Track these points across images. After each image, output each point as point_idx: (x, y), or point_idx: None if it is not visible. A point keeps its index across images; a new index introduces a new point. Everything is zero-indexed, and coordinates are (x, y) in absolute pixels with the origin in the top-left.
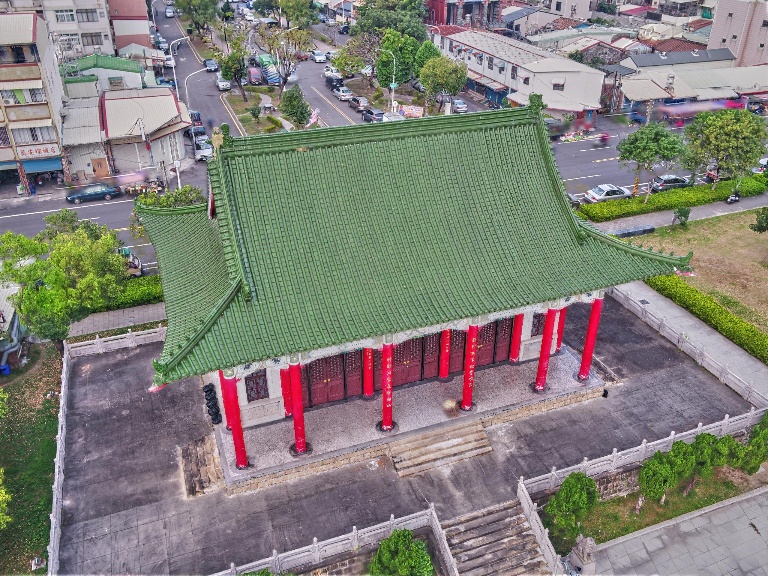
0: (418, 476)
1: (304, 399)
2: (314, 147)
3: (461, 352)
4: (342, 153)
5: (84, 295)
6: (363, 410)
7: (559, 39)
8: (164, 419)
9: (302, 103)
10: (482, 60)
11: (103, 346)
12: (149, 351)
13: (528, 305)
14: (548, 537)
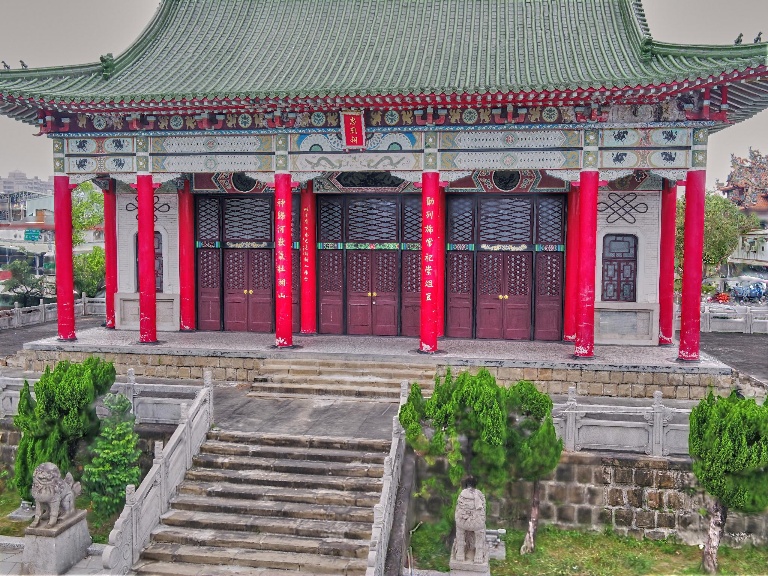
0: (272, 399)
1: (215, 316)
2: None
3: (469, 300)
4: None
5: None
6: None
7: None
8: None
9: None
10: None
11: None
12: None
13: (534, 153)
14: (441, 541)
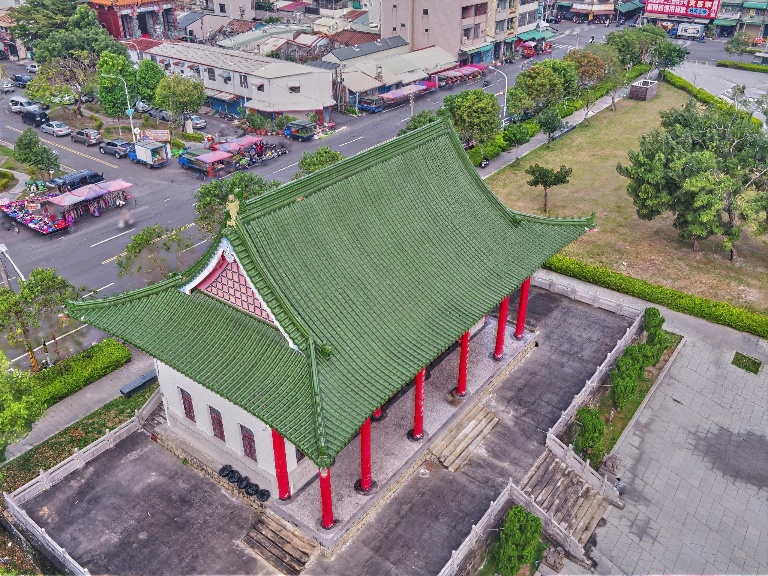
0: (466, 465)
1: None
2: (309, 194)
3: None
4: (331, 194)
5: (7, 430)
6: (385, 430)
7: (250, 42)
8: (194, 522)
9: (44, 148)
10: (199, 72)
11: (49, 480)
12: (105, 464)
13: None
14: None
